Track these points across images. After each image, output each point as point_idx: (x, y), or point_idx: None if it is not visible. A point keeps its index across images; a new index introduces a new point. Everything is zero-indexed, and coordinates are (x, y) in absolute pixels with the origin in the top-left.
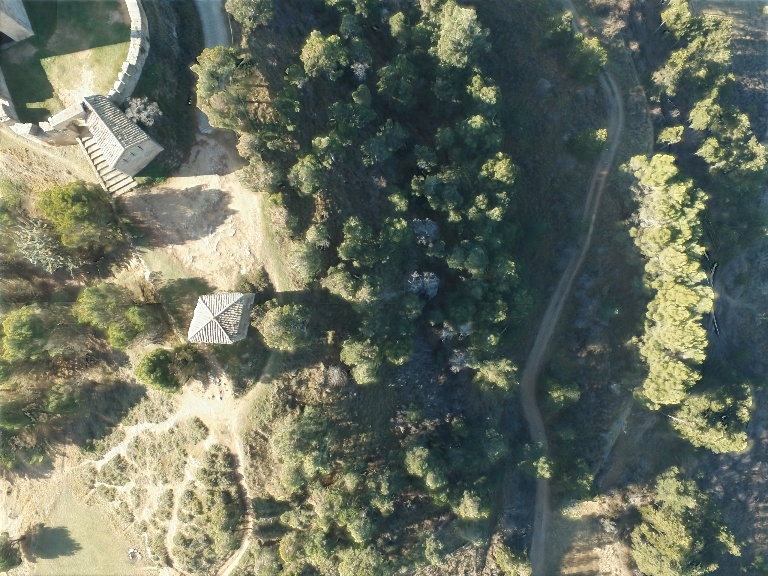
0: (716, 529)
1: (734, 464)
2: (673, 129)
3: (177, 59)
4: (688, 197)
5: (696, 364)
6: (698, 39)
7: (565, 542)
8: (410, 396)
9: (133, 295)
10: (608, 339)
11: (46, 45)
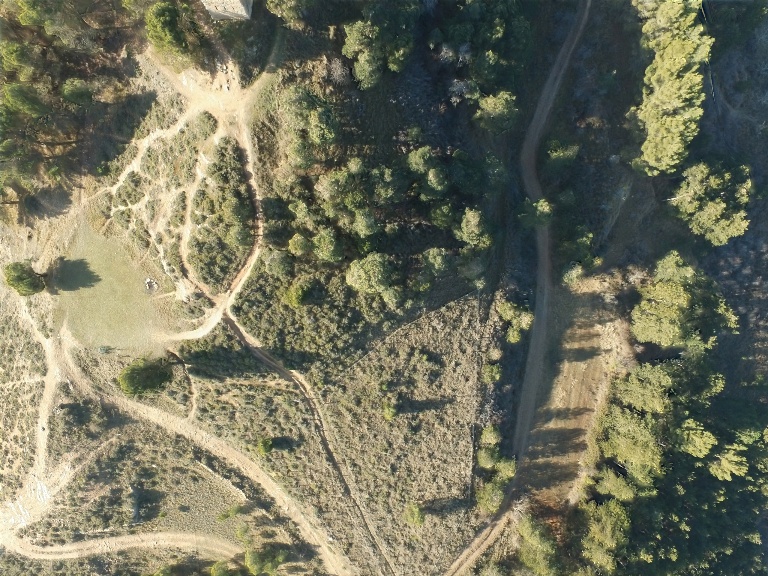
0: (715, 302)
1: (734, 272)
2: None
3: None
4: None
5: (694, 121)
6: None
7: (567, 317)
8: (411, 118)
9: None
10: (607, 114)
11: None
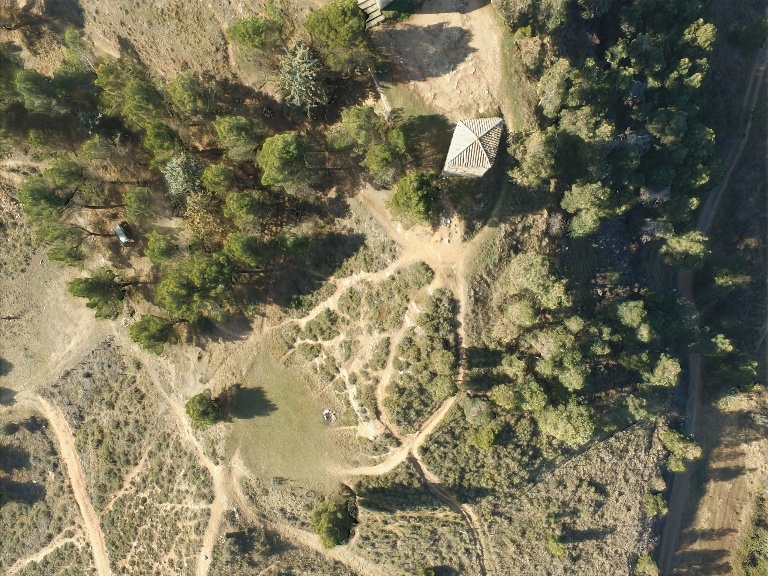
0: None
1: None
2: None
3: None
4: None
5: None
6: None
7: (714, 436)
8: (608, 260)
9: None
10: (763, 234)
11: None
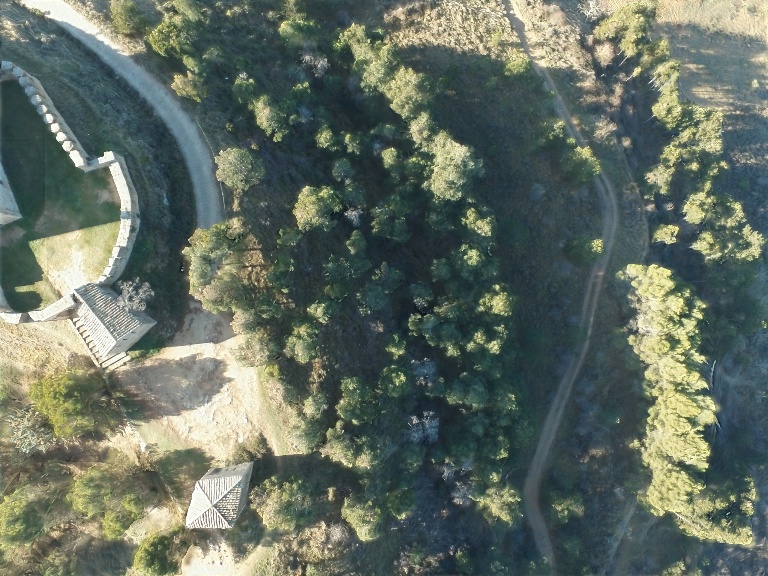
0: None
1: (739, 544)
2: (668, 230)
3: (168, 229)
4: (686, 308)
5: (699, 472)
6: (689, 130)
7: None
8: (413, 535)
9: (129, 460)
10: (610, 441)
11: (34, 227)
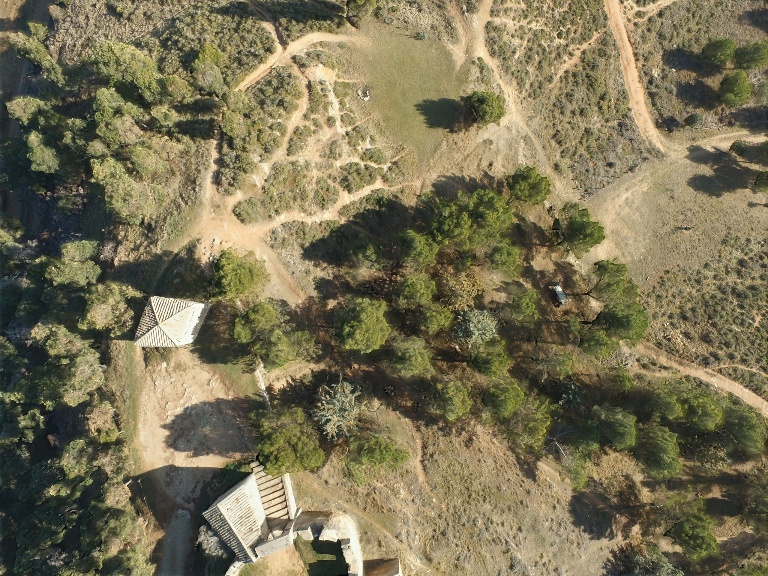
0: None
1: None
2: None
3: None
4: None
5: None
6: None
7: (5, 62)
8: (70, 222)
9: None
10: None
11: None
